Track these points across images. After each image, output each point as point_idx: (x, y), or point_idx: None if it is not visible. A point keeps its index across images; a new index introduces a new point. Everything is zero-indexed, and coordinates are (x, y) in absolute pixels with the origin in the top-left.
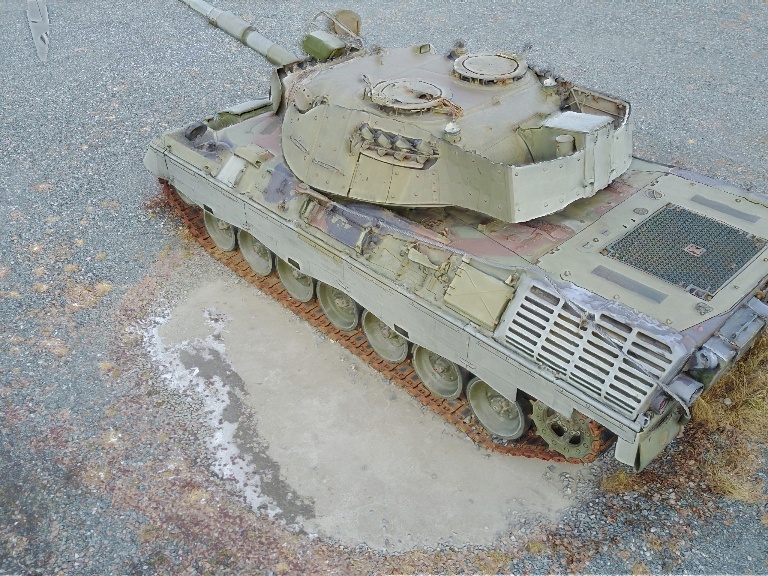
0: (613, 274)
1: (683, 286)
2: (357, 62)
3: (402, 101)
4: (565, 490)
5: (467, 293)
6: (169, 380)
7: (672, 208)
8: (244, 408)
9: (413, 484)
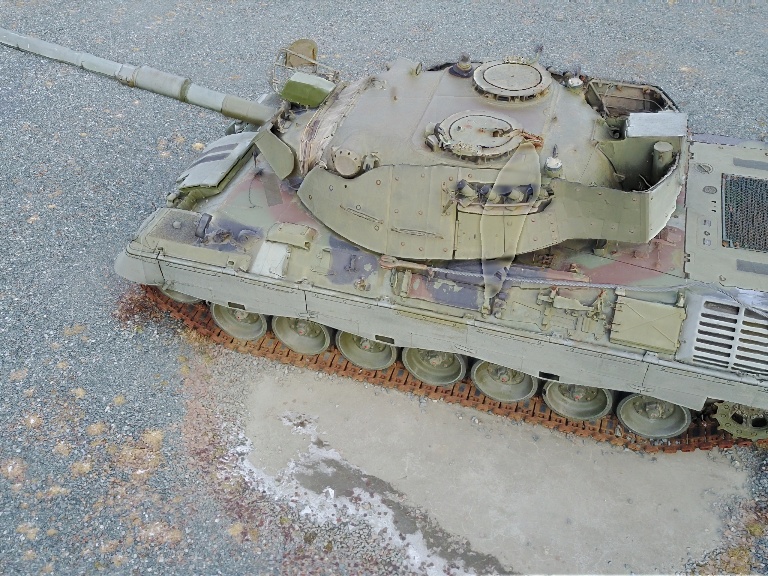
0: (755, 265)
1: None
2: (365, 102)
3: (486, 146)
4: (735, 464)
5: (636, 326)
6: (312, 515)
7: (730, 179)
8: (412, 511)
9: (620, 518)
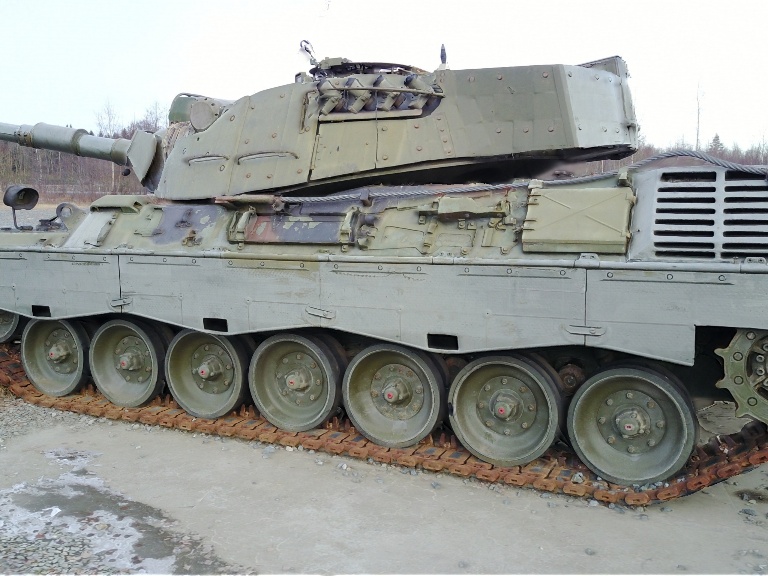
0: None
1: None
2: None
3: None
4: None
5: (559, 218)
6: None
7: None
8: (175, 537)
9: (565, 567)
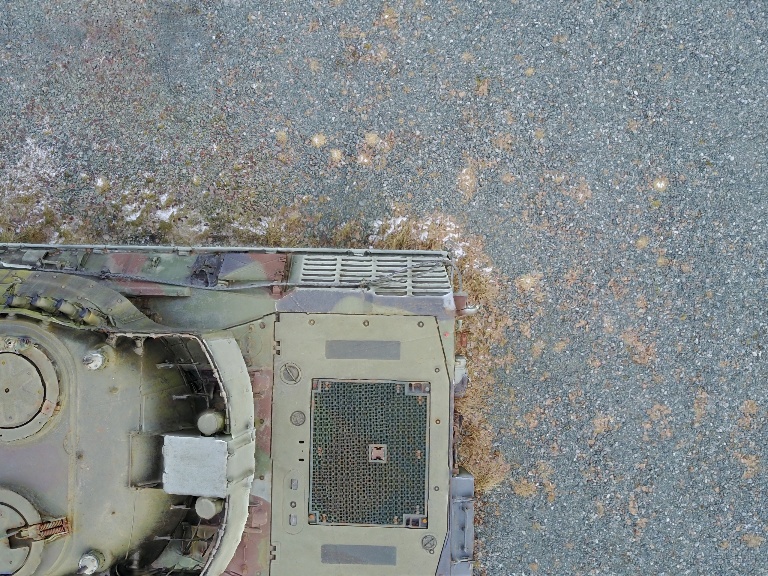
0: (339, 551)
1: (399, 524)
2: None
3: (4, 573)
4: None
5: None
6: None
7: (320, 390)
8: None
9: None
